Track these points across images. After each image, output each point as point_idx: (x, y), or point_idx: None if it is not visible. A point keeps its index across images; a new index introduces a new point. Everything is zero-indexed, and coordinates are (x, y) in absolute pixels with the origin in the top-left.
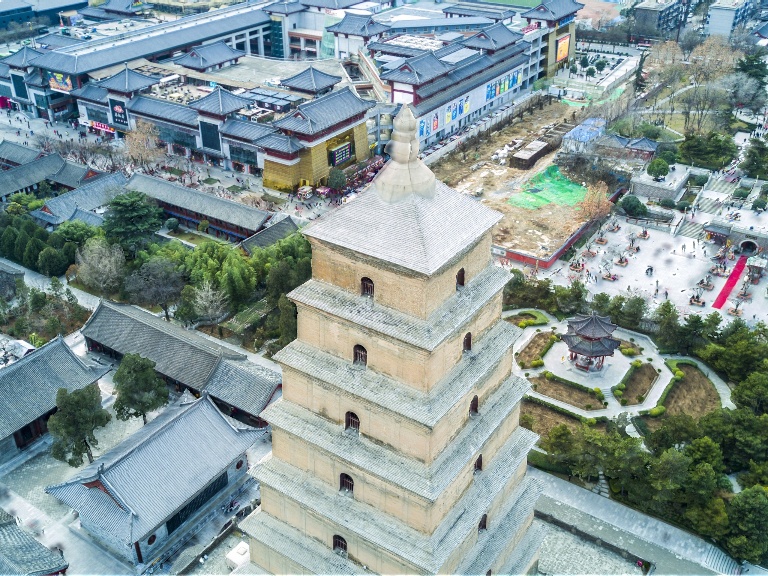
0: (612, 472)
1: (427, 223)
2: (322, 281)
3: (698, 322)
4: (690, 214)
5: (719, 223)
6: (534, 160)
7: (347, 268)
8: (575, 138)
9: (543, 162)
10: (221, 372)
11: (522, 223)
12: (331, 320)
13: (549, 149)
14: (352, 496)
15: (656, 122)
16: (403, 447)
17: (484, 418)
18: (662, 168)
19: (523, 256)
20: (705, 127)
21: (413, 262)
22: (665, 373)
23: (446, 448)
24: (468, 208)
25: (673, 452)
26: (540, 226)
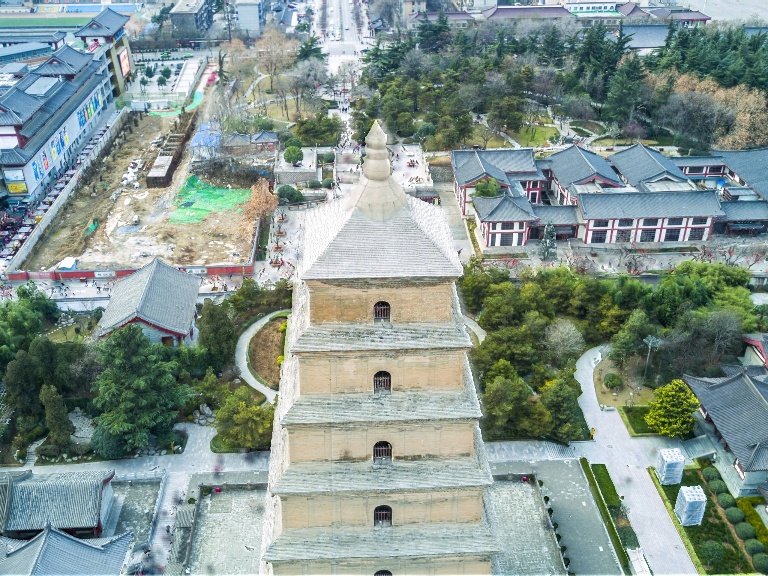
0: None
1: (424, 231)
2: (324, 323)
3: None
4: (337, 189)
5: None
6: (169, 176)
7: (357, 299)
8: (206, 145)
9: (179, 175)
10: (19, 500)
11: (198, 238)
12: (346, 358)
13: (175, 162)
14: (390, 525)
15: (259, 115)
16: (444, 451)
17: None
18: (298, 154)
19: (226, 268)
20: (306, 111)
21: (440, 269)
22: None
23: None
24: (426, 209)
25: (499, 380)
26: (217, 236)
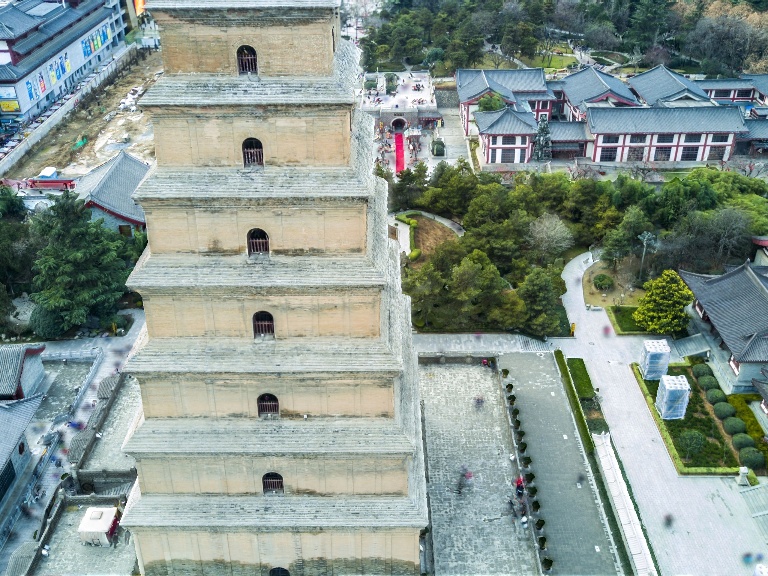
0: (417, 305)
1: None
2: (180, 73)
3: (409, 175)
4: None
5: (368, 109)
6: None
7: (215, 42)
8: None
9: None
10: None
11: None
12: (206, 118)
13: None
14: (272, 337)
15: None
16: (331, 244)
17: (375, 211)
18: None
19: None
20: None
21: None
22: (401, 226)
23: (367, 237)
24: None
25: (466, 262)
26: None
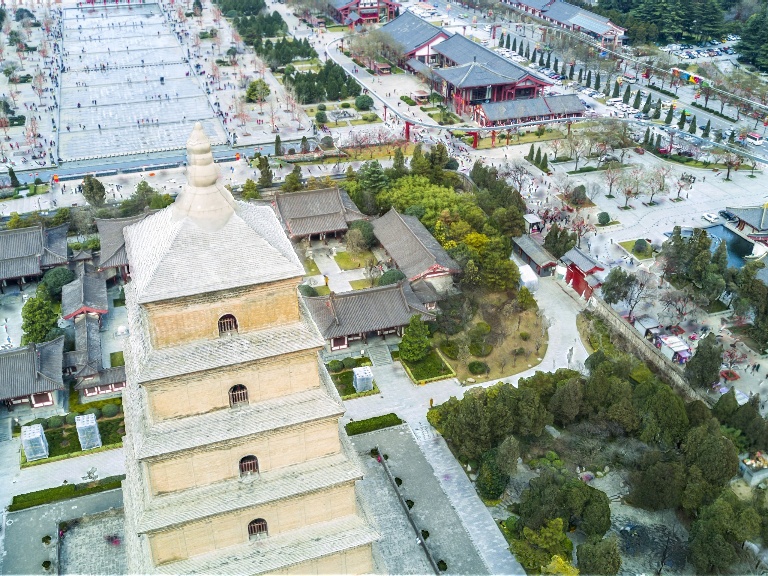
0: None
1: None
2: None
3: None
4: None
5: None
6: None
7: None
8: None
9: None
10: None
11: None
12: None
13: None
14: None
15: None
16: None
17: None
18: None
19: None
20: None
21: None
22: None
23: None
24: None
25: None
26: None
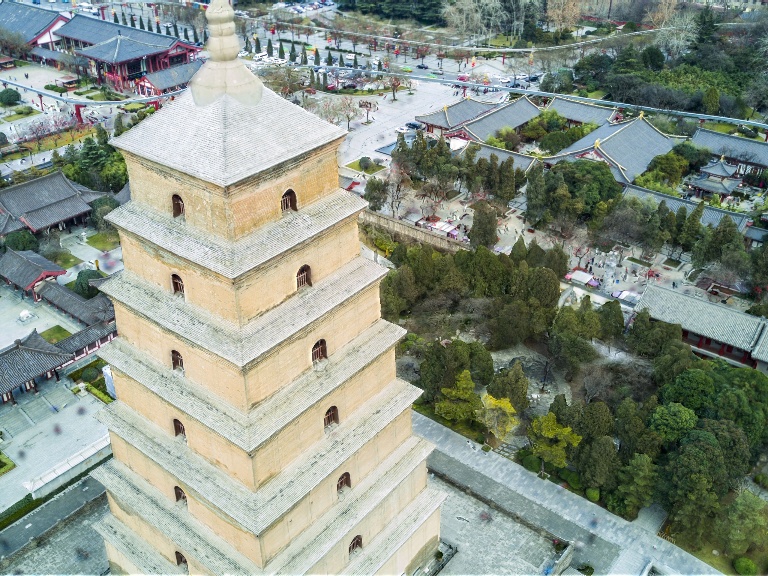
0: None
1: None
2: None
3: None
4: None
5: None
6: None
7: None
8: None
9: None
10: None
11: None
12: None
13: None
14: None
15: None
16: None
17: None
18: None
19: None
20: None
21: None
22: None
23: None
24: None
25: None
26: None
